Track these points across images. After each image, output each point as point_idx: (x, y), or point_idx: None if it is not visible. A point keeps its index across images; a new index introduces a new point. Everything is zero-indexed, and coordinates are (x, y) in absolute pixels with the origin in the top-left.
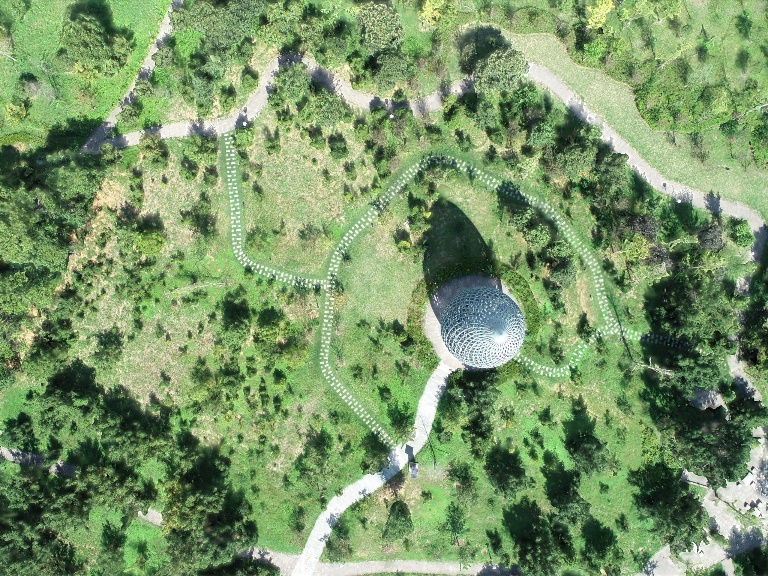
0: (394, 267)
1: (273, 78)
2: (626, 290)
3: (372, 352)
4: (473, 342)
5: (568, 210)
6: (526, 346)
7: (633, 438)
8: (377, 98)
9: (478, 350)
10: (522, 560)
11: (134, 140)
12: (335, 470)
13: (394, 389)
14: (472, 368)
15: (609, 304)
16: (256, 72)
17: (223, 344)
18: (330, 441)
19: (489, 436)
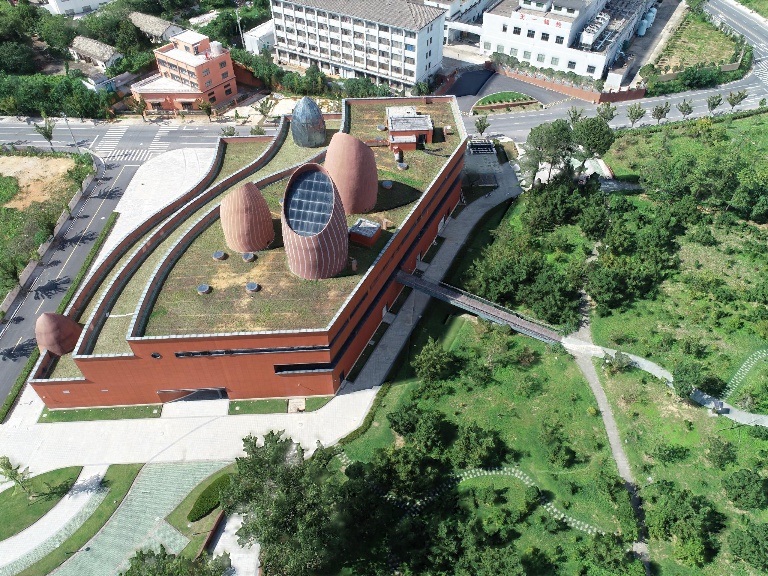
0: None
1: None
2: None
3: None
4: None
5: None
6: None
7: None
8: None
9: None
10: None
11: None
12: None
13: None
14: None
15: None
16: None
17: None
18: None
19: None
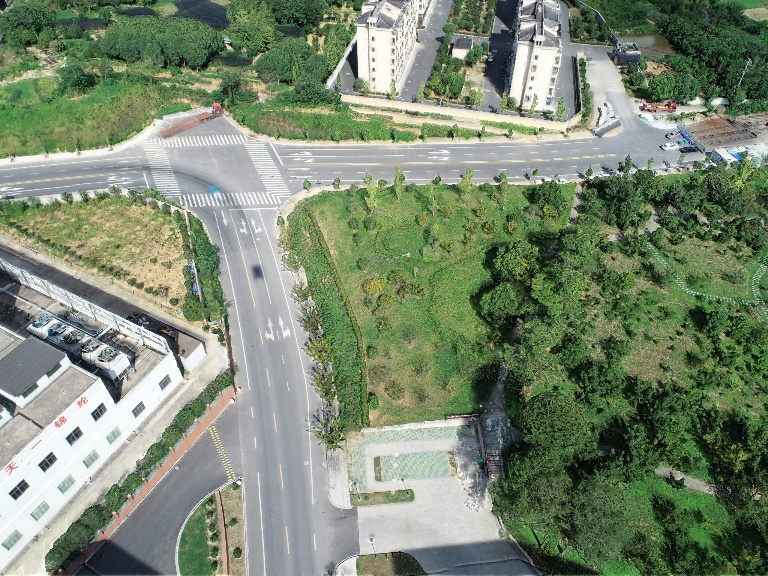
0: None
1: (655, 217)
2: None
3: None
4: None
5: None
6: None
7: None
8: (726, 221)
9: None
10: None
11: None
12: None
13: None
14: None
15: None
16: None
17: None
18: None
19: None
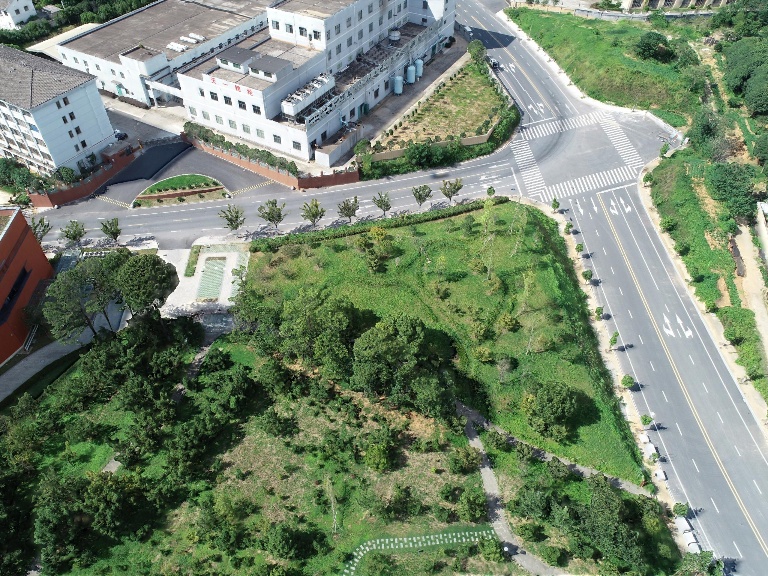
0: None
1: None
2: None
3: None
4: None
5: None
6: None
7: None
8: None
9: None
10: None
11: (475, 445)
12: None
13: None
14: None
15: None
16: (567, 564)
17: None
18: None
19: None
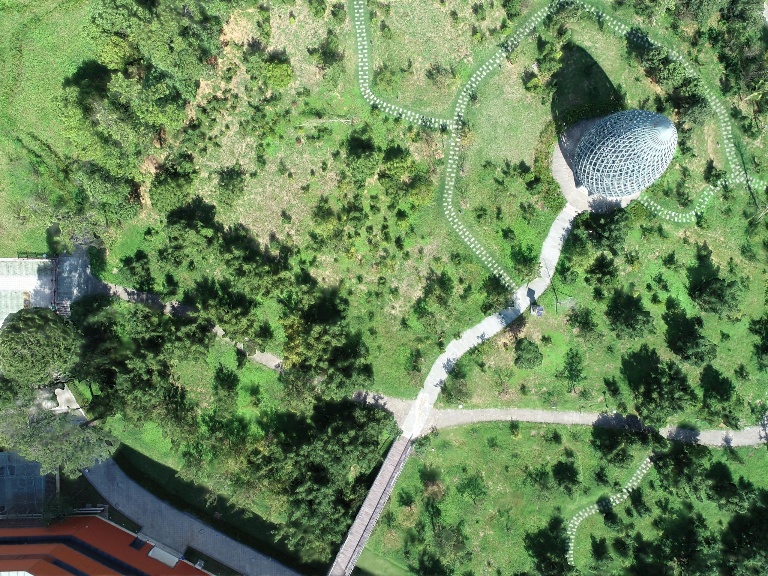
0: (521, 109)
1: None
2: (756, 135)
3: (497, 193)
4: (631, 146)
5: (696, 58)
6: (654, 189)
7: (756, 287)
8: None
9: (635, 155)
10: (647, 399)
11: None
12: (454, 313)
13: (518, 231)
14: (598, 210)
15: (736, 152)
16: None
17: (347, 183)
18: (452, 282)
19: (616, 275)
